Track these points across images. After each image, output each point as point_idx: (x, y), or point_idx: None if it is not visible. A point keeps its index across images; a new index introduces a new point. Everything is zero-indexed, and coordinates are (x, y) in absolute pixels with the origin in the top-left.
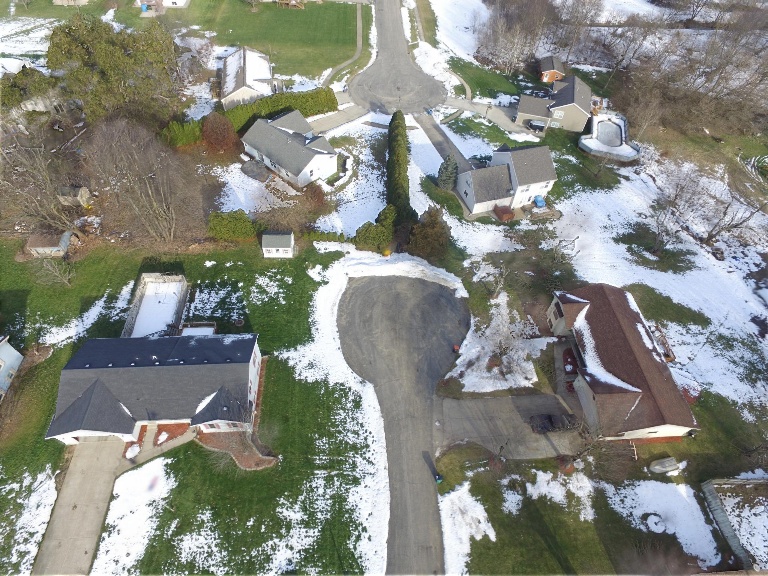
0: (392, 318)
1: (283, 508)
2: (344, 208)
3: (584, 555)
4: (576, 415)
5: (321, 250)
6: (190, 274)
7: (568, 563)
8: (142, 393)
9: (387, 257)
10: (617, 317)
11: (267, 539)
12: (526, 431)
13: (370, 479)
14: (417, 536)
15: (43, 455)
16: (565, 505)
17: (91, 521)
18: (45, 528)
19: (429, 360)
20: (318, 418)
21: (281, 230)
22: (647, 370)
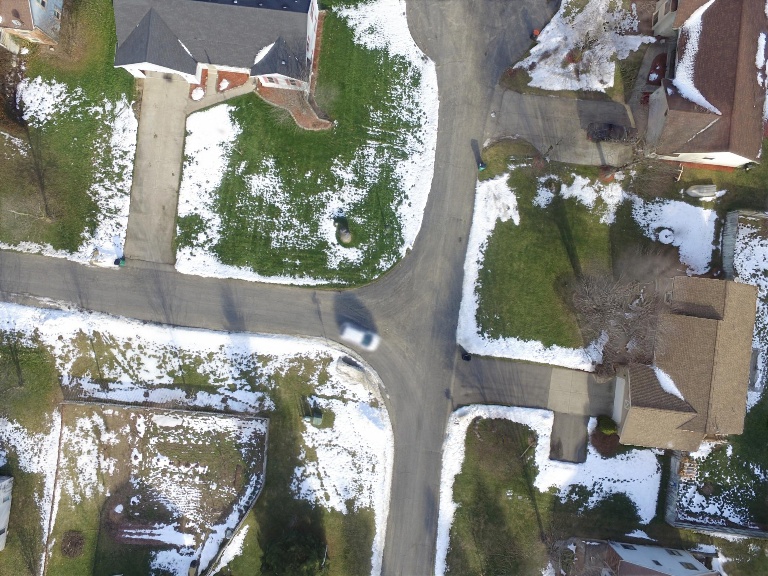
0: None
1: (337, 168)
2: None
3: (591, 248)
4: (638, 129)
5: None
6: None
7: (575, 251)
8: (199, 32)
9: None
10: (741, 21)
11: (322, 190)
12: (580, 137)
13: (417, 156)
14: (451, 210)
15: (116, 84)
16: (591, 208)
17: (172, 150)
18: (135, 149)
19: (501, 44)
20: (374, 90)
21: None
22: (741, 92)
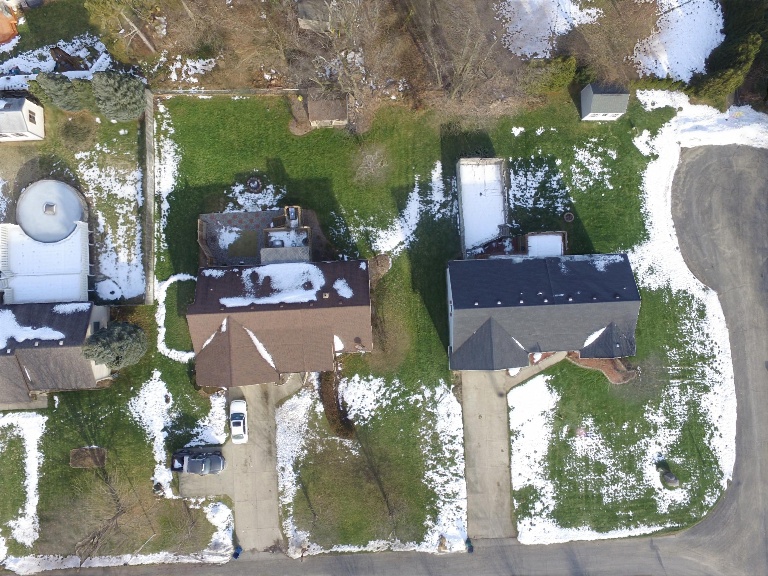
0: (734, 209)
1: (649, 413)
2: (666, 23)
3: None
4: None
5: (648, 106)
6: (500, 149)
7: None
8: (533, 330)
9: (726, 114)
10: None
11: (640, 438)
12: None
13: (718, 387)
14: (760, 434)
15: (432, 371)
16: None
17: (498, 428)
18: (463, 433)
19: None
20: (666, 329)
21: (619, 87)
22: None
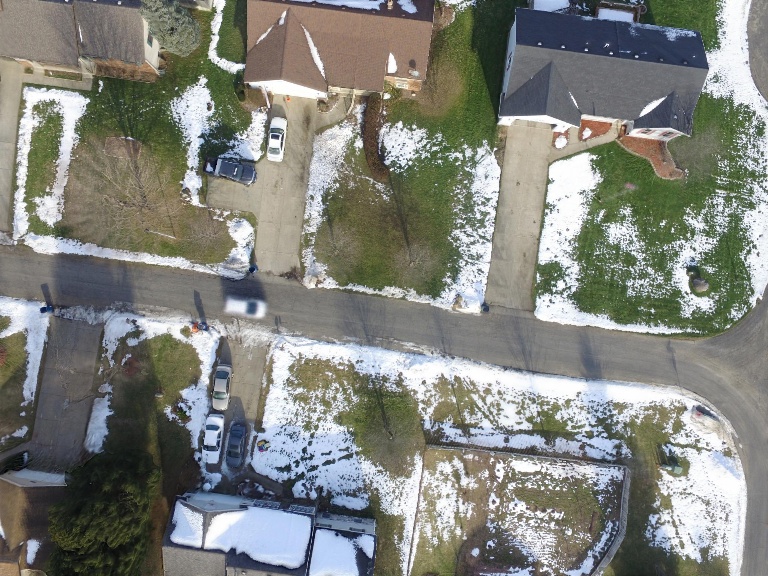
0: None
1: (689, 217)
2: None
3: None
4: None
5: None
6: None
7: None
8: (592, 85)
9: None
10: None
11: (676, 239)
12: None
13: (764, 206)
14: None
15: (477, 130)
16: None
17: (534, 198)
18: (498, 196)
19: None
20: (721, 139)
21: None
22: None
